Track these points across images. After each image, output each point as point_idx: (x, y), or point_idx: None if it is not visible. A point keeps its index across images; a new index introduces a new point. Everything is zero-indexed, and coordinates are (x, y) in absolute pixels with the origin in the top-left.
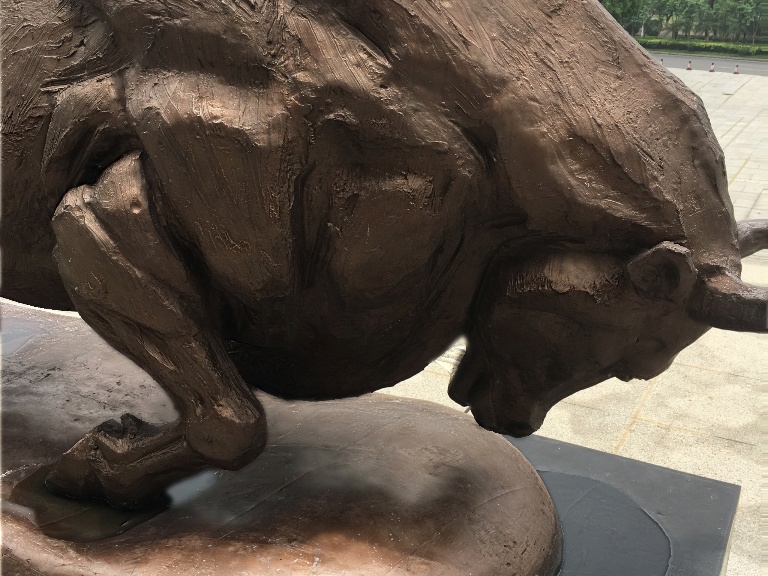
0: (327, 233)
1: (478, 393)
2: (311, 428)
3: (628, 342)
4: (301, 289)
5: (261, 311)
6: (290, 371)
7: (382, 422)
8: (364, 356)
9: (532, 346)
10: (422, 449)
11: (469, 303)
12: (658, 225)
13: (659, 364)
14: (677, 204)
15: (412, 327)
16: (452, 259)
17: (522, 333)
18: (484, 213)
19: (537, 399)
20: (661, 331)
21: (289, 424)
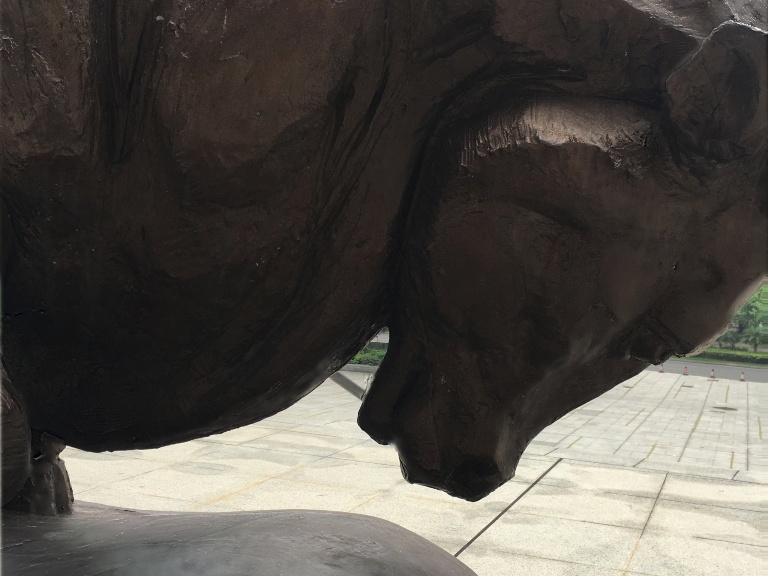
0: (155, 36)
1: (409, 404)
2: (137, 533)
3: (661, 270)
4: (107, 160)
5: (33, 200)
6: (96, 385)
7: (253, 516)
8: (219, 337)
9: (501, 287)
10: (315, 537)
11: (396, 212)
12: (705, 37)
13: (713, 314)
14: (730, 9)
15: (300, 272)
16: (368, 119)
17: (485, 256)
18: (421, 23)
19: (508, 412)
20: (716, 244)
21: (104, 533)
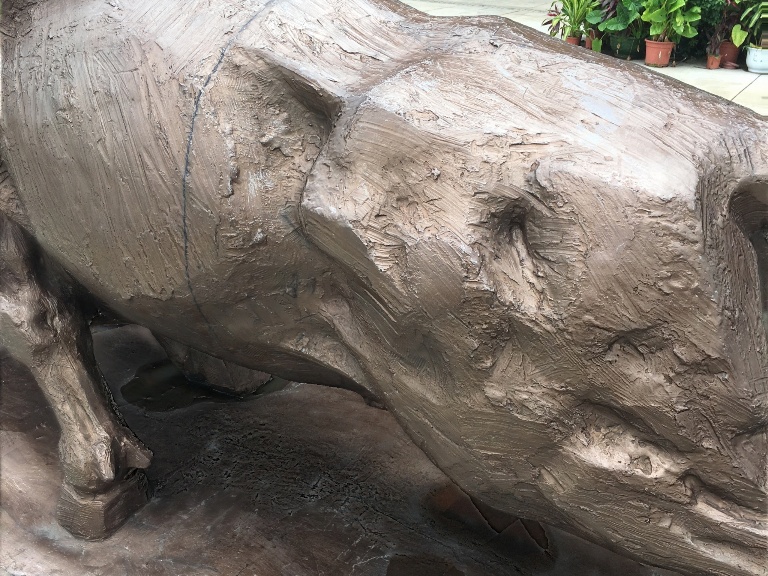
0: None
1: None
2: (41, 394)
3: None
4: None
5: None
6: None
7: None
8: None
9: None
10: None
11: None
12: None
13: None
14: None
15: None
16: None
17: None
18: None
19: None
20: None
21: None
